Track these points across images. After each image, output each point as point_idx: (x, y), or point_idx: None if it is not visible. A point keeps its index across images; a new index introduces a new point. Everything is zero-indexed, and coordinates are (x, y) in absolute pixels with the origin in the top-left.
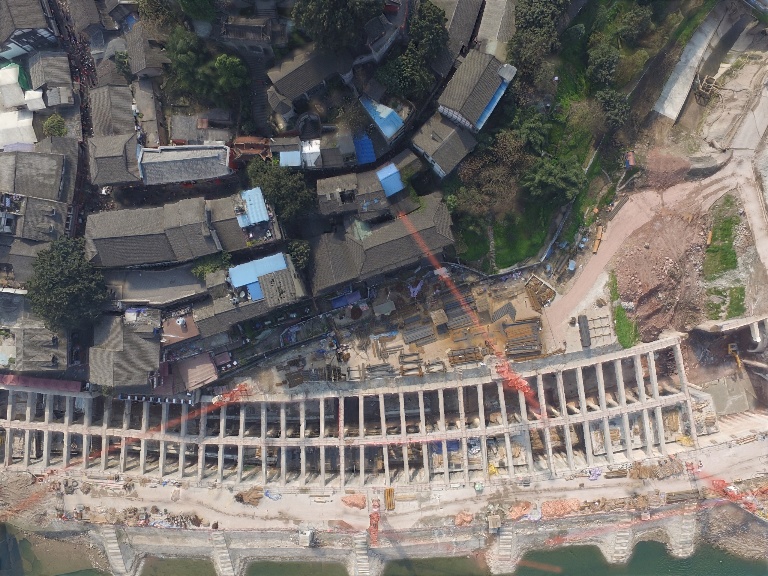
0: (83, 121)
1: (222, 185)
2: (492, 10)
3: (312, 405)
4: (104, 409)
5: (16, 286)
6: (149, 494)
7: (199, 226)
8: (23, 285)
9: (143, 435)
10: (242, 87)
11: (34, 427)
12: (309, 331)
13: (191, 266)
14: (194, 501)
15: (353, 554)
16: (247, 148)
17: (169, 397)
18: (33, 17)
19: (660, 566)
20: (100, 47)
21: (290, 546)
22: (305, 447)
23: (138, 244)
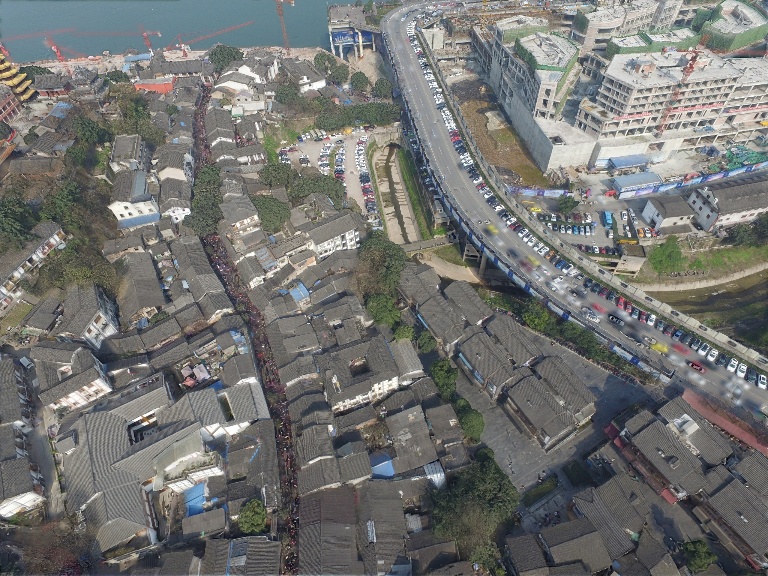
0: None
1: None
2: None
3: None
4: None
5: None
6: None
7: None
8: None
9: None
10: None
11: None
12: None
13: None
14: None
15: None
16: None
17: None
18: None
19: None
20: None
21: None
22: None
23: None
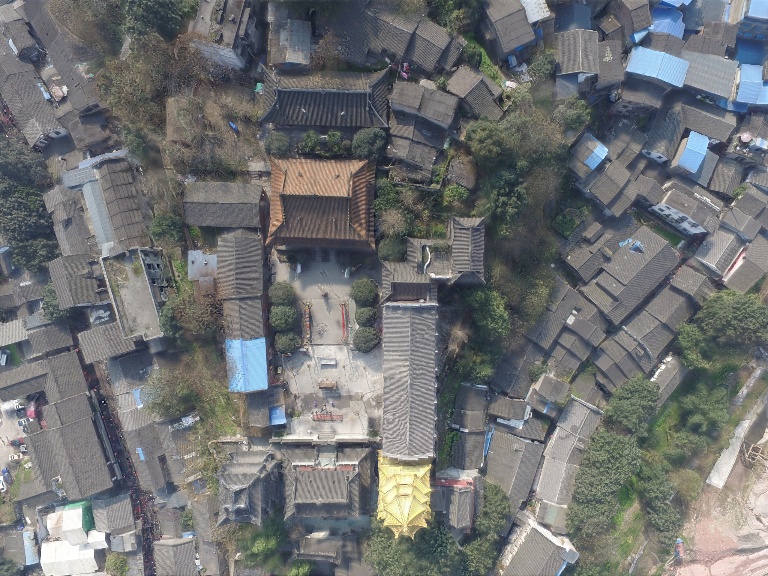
0: (145, 559)
1: None
2: (551, 470)
3: None
4: None
5: None
6: None
7: None
8: None
9: None
10: None
11: None
12: None
13: None
14: None
15: None
16: None
17: None
18: (99, 480)
19: None
20: (163, 497)
21: None
22: None
23: None
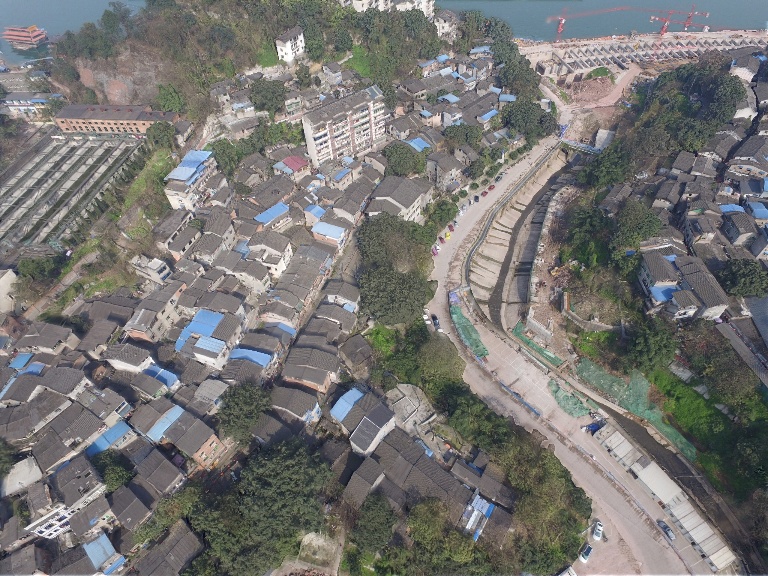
0: None
1: None
2: None
3: None
4: None
5: None
6: None
7: None
8: None
9: None
10: None
11: None
12: None
13: None
14: None
15: None
16: None
17: None
18: None
19: None
20: None
21: None
22: None
23: None
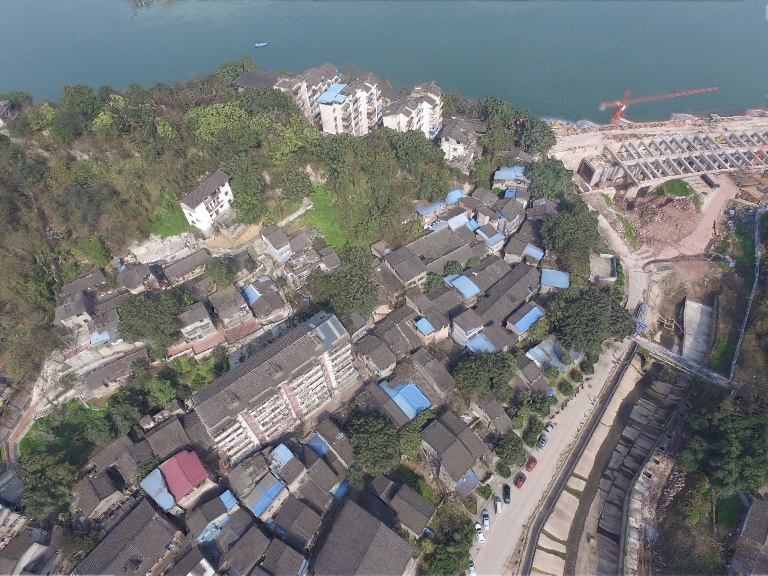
0: None
1: None
2: None
3: None
4: None
5: None
6: None
7: None
8: None
9: None
10: None
11: None
12: None
13: None
14: None
15: None
16: None
17: None
18: None
19: (593, 118)
20: None
21: None
22: None
23: None
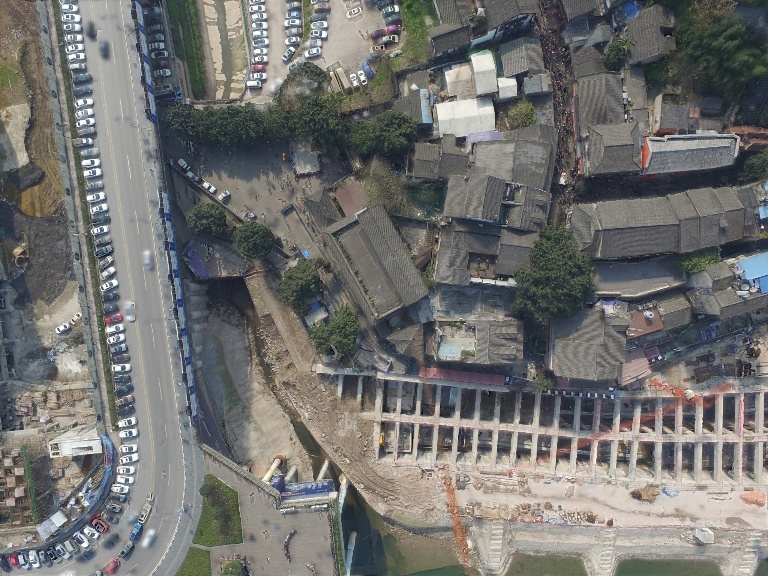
0: (554, 109)
1: (690, 176)
2: None
3: (672, 401)
4: (496, 403)
5: (487, 277)
6: (542, 490)
7: (718, 217)
8: (501, 276)
9: (537, 430)
10: (758, 75)
11: (425, 421)
12: (729, 326)
13: (664, 258)
14: (589, 497)
15: (738, 552)
16: (748, 138)
17: (590, 392)
18: (530, 2)
19: None
20: (584, 33)
21: (677, 544)
22: (702, 443)
23: (645, 235)
